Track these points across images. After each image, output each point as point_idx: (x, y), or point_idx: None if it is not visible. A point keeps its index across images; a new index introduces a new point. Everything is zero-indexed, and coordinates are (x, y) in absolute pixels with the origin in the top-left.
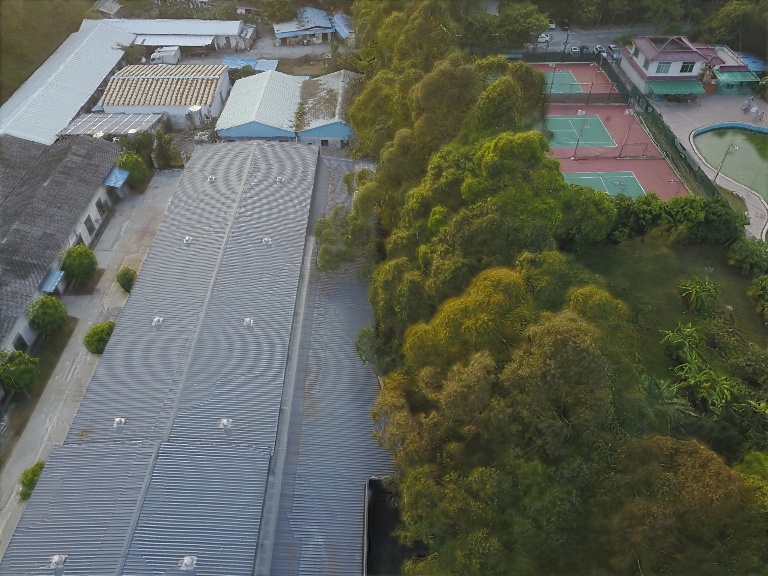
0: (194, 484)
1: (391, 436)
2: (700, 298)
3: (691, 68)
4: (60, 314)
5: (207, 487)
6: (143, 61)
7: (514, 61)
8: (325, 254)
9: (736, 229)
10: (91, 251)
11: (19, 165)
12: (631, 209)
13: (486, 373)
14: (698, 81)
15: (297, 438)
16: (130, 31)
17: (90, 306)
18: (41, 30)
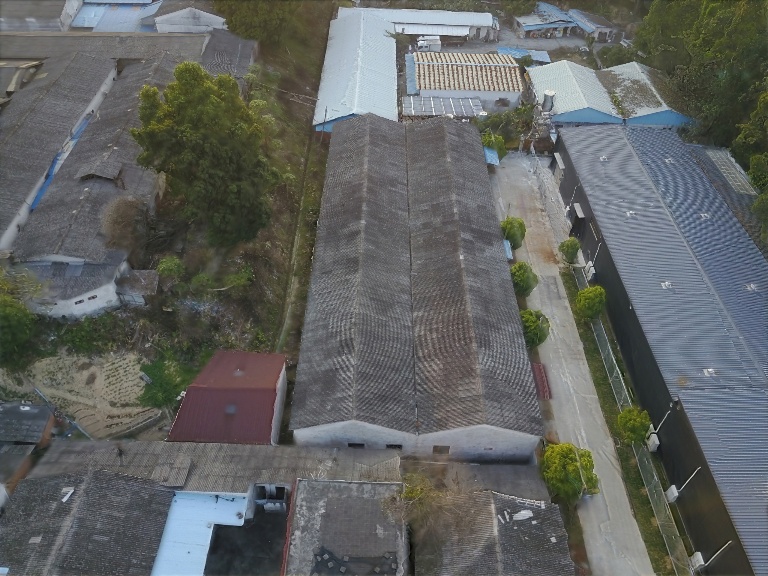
0: None
1: None
2: None
3: None
4: (537, 279)
5: None
6: (410, 49)
7: None
8: None
9: None
10: None
11: (396, 142)
12: None
13: None
14: None
15: None
16: (388, 20)
17: None
18: (302, 16)
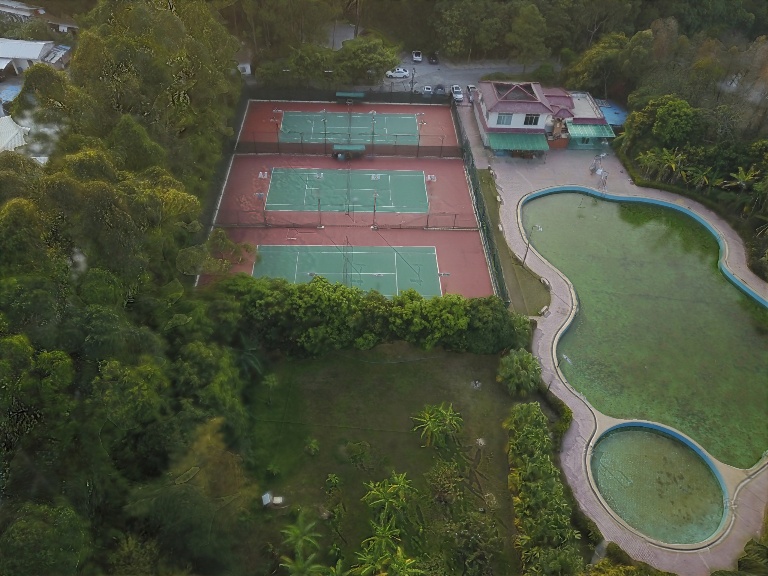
0: None
1: None
2: (434, 434)
3: (536, 120)
4: None
5: None
6: None
7: (356, 100)
8: None
9: (513, 335)
10: None
11: None
12: (376, 313)
13: None
14: (546, 134)
15: None
16: None
17: None
18: None
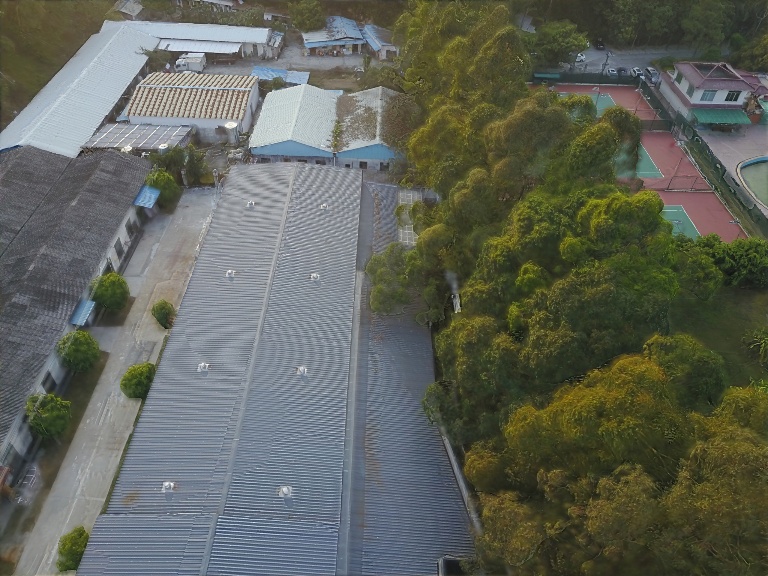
0: (257, 567)
1: (514, 551)
2: None
3: (736, 97)
4: (93, 351)
5: (272, 571)
6: (167, 67)
7: (551, 81)
8: (381, 295)
9: None
10: (124, 280)
11: (43, 180)
12: None
13: (645, 496)
14: (742, 110)
15: (360, 507)
16: (154, 35)
17: (121, 339)
18: (60, 30)
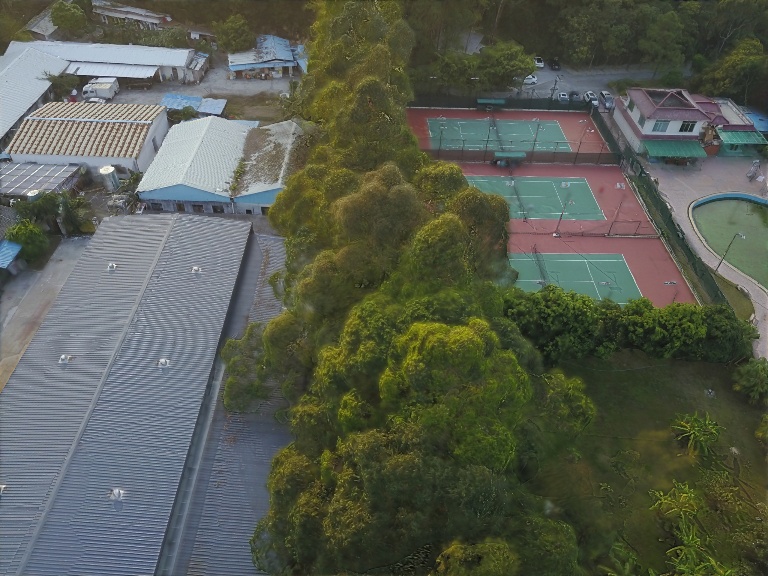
0: None
1: None
2: (699, 443)
3: (692, 127)
4: None
5: None
6: (74, 94)
7: (495, 107)
8: (231, 390)
9: (742, 344)
10: None
11: None
12: (619, 321)
13: None
14: (699, 141)
15: None
16: (63, 57)
17: None
18: None
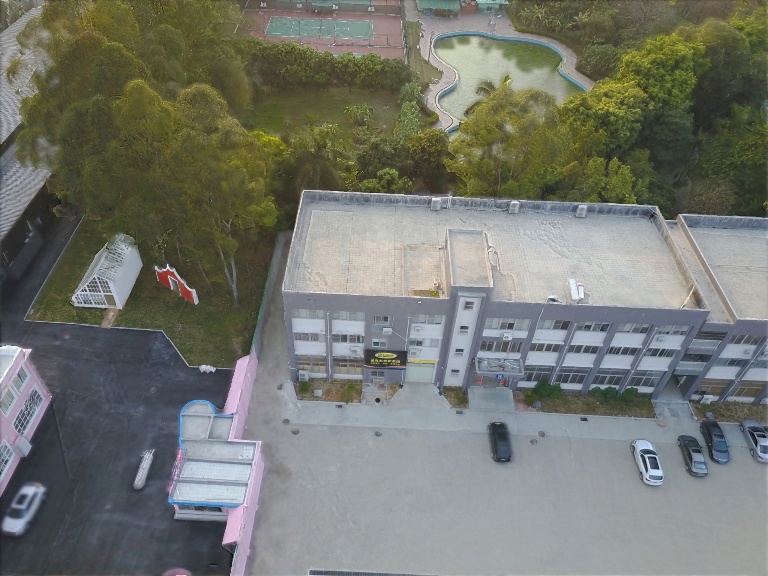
0: None
1: None
2: (355, 114)
3: None
4: None
5: None
6: None
7: None
8: None
9: (410, 81)
10: None
11: None
12: (327, 59)
13: (33, 21)
14: (460, 2)
15: None
16: None
17: None
18: None
